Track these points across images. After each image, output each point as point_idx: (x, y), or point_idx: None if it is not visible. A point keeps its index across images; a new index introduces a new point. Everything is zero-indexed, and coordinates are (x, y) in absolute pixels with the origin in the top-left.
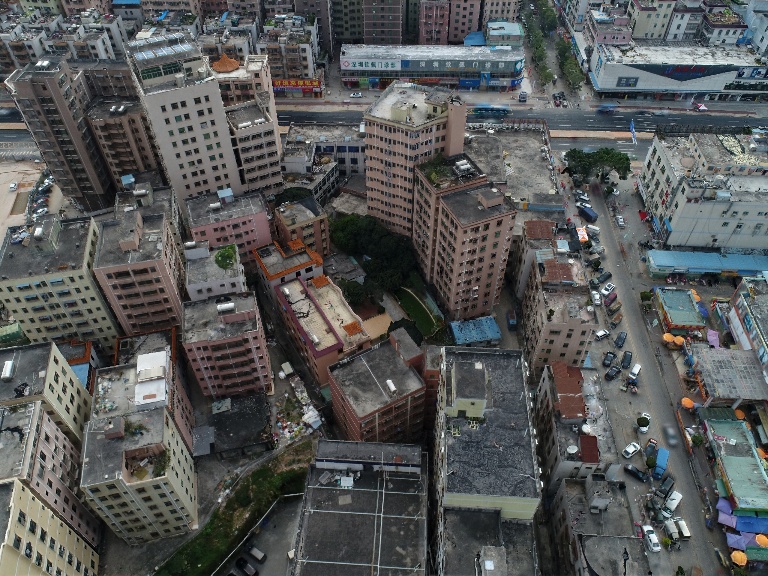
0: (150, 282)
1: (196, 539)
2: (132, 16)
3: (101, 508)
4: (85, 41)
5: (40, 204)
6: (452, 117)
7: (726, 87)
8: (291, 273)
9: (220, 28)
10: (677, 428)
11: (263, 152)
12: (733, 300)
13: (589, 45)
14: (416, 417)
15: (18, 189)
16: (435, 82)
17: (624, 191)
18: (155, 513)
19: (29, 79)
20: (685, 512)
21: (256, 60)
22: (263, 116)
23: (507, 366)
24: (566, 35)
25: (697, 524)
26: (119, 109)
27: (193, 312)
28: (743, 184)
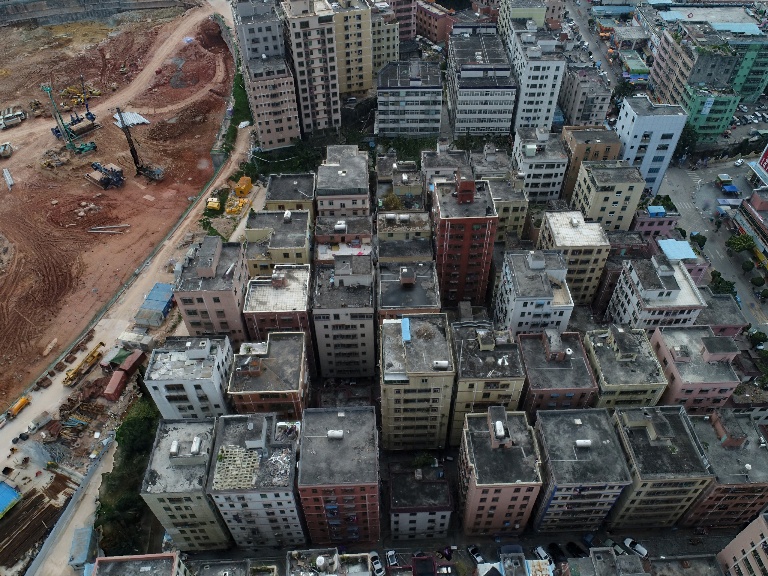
0: None
1: None
2: None
3: None
4: None
5: None
6: None
7: None
8: None
9: None
10: (606, 61)
11: None
12: None
13: None
14: None
15: None
16: None
17: None
18: (387, 53)
19: None
20: None
21: None
22: None
23: None
24: None
25: (614, 82)
26: None
27: None
28: None
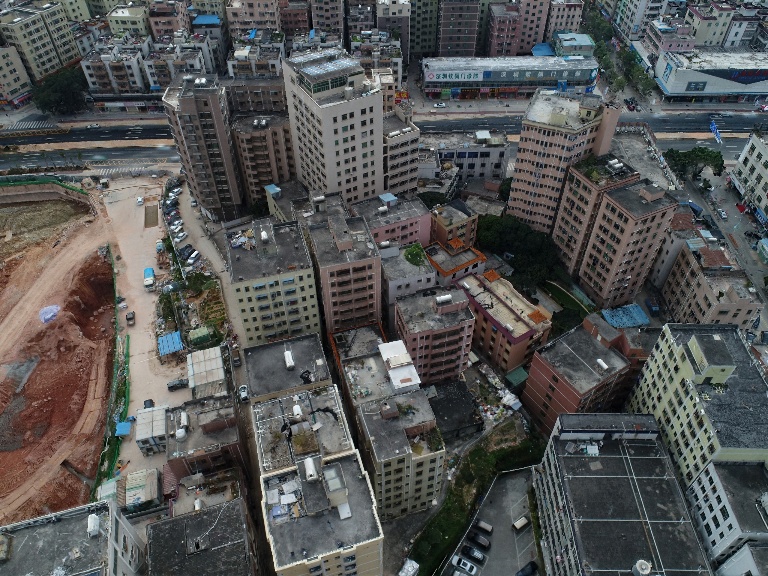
0: (363, 279)
1: (440, 513)
2: (211, 35)
3: (381, 483)
4: (184, 60)
5: (174, 216)
6: (608, 120)
7: None
8: (462, 269)
9: (313, 45)
10: None
11: (407, 159)
12: None
13: (652, 53)
14: (612, 394)
15: (144, 203)
16: (514, 91)
17: (717, 187)
18: (416, 488)
19: (194, 96)
20: None
21: (382, 73)
22: (406, 125)
23: (727, 339)
24: (620, 44)
25: None
26: (262, 123)
27: (406, 305)
28: None
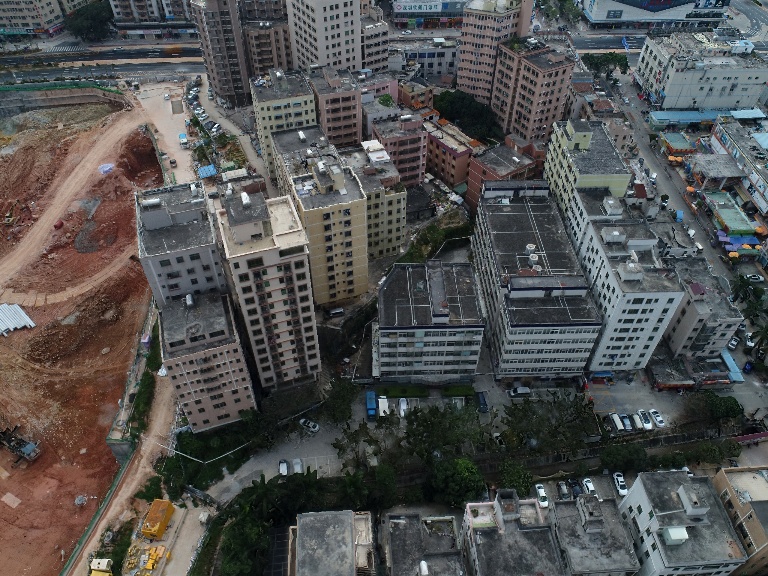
0: (349, 108)
1: (406, 256)
2: None
3: None
4: None
5: (196, 105)
6: (525, 7)
7: (687, 16)
8: None
9: None
10: (685, 204)
11: (379, 49)
12: (712, 134)
13: None
14: None
15: (170, 98)
16: None
17: (624, 84)
18: (389, 229)
19: None
20: (698, 241)
21: None
22: None
23: (594, 129)
24: None
25: (706, 246)
26: (267, 24)
27: (380, 126)
28: (711, 61)
